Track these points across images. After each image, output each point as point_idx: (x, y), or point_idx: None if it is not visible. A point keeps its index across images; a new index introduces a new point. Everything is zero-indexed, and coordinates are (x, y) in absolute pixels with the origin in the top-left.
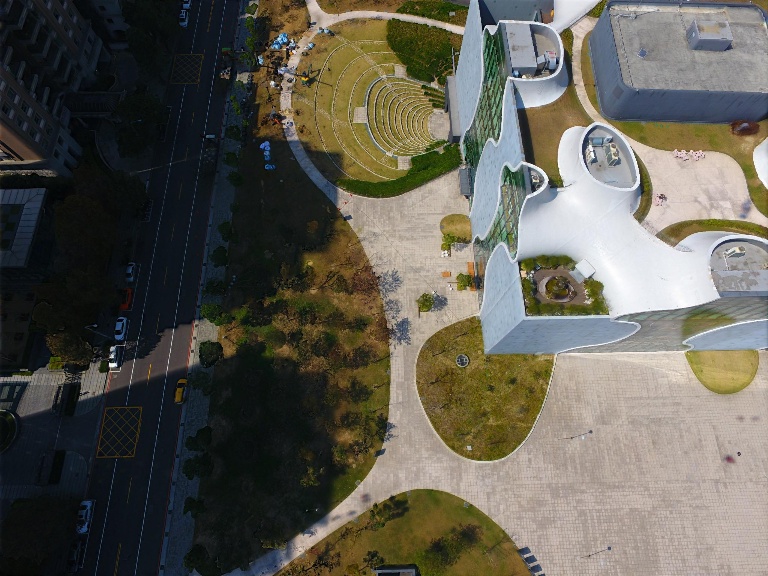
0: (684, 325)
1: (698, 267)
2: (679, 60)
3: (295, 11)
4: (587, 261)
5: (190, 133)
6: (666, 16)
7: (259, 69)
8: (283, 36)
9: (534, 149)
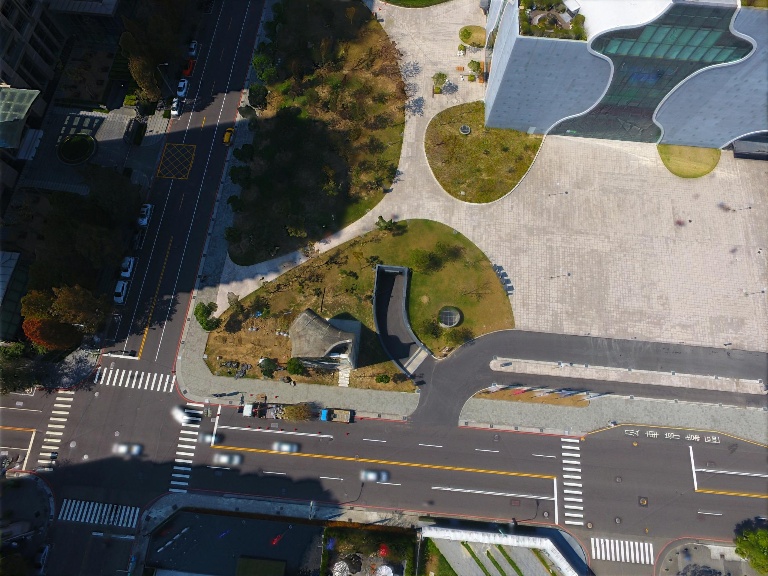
0: (650, 72)
1: None
2: None
3: None
4: None
5: None
6: None
7: None
8: None
9: None
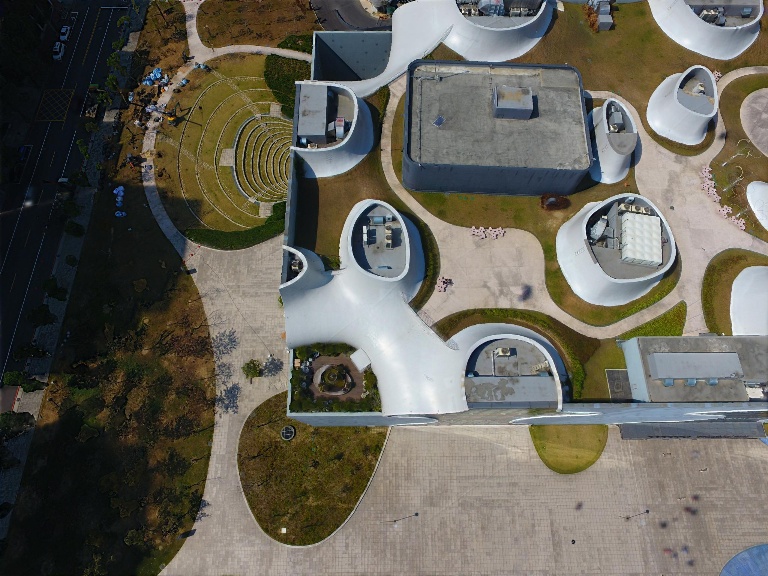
0: None
1: (456, 370)
2: (477, 130)
3: (174, 44)
4: (363, 351)
5: (47, 175)
6: (474, 79)
7: (128, 106)
8: (156, 72)
9: (318, 224)
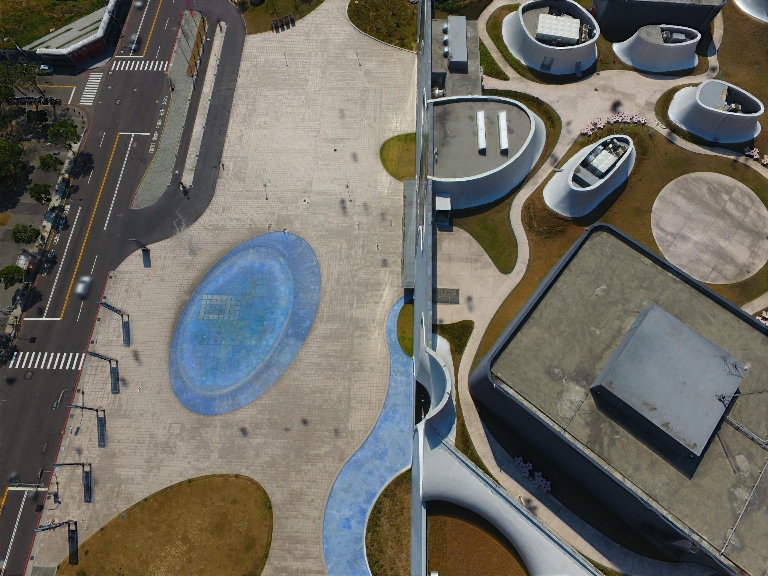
0: None
1: None
2: None
3: None
4: None
5: None
6: None
7: None
8: None
9: None
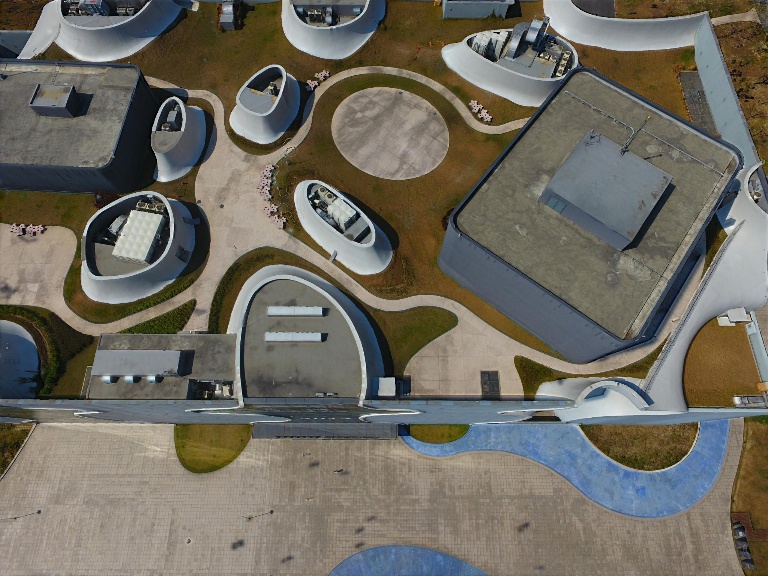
0: None
1: None
2: (18, 127)
3: None
4: None
5: None
6: (39, 77)
7: None
8: None
9: None
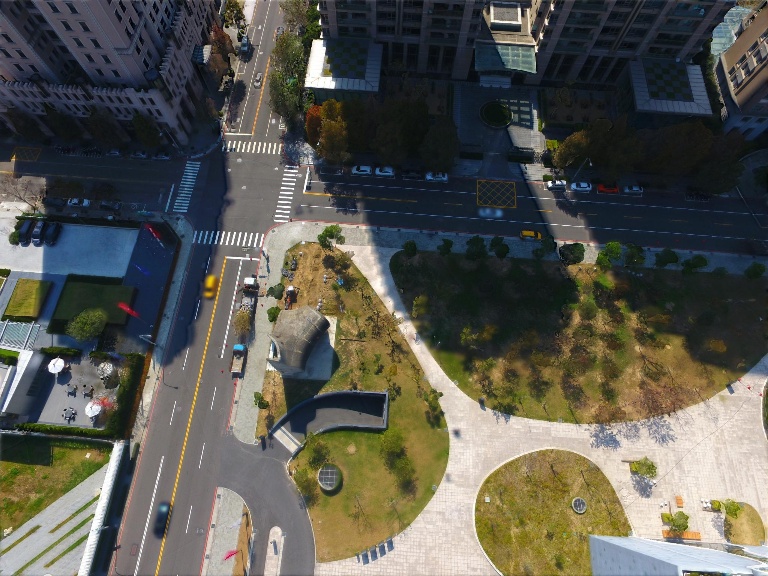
0: None
1: None
2: None
3: None
4: None
5: None
6: None
7: None
8: None
9: None
